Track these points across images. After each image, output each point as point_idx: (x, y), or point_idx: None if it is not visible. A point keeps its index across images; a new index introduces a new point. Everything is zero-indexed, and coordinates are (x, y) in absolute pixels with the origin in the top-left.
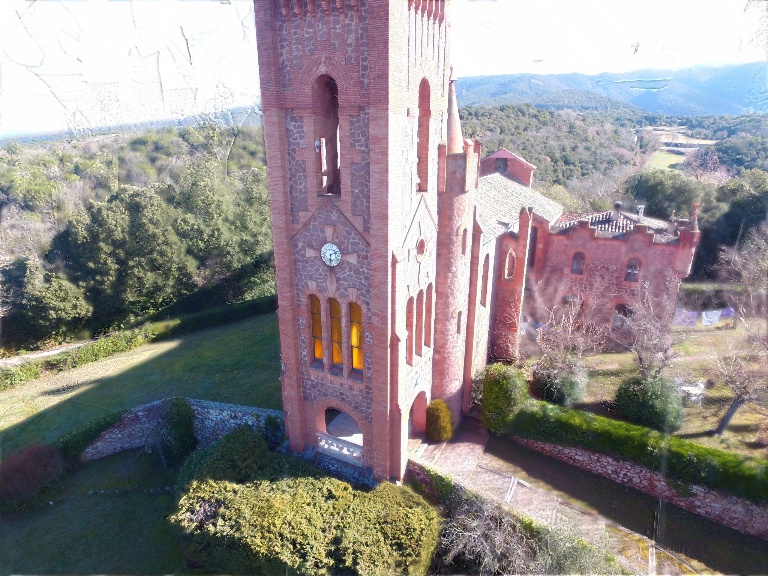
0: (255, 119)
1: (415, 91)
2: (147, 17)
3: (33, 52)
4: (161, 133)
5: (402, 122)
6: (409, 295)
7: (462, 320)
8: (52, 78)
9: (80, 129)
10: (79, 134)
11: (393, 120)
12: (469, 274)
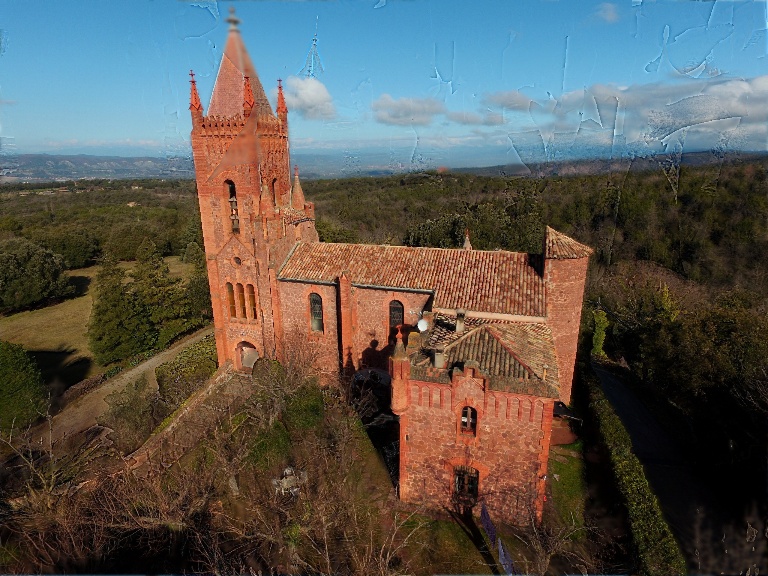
0: (644, 164)
1: (220, 186)
2: (581, 80)
3: (480, 125)
4: (603, 173)
5: (210, 200)
6: (227, 281)
7: (265, 316)
8: (518, 135)
9: (499, 172)
10: (499, 175)
11: (202, 199)
12: (269, 291)
